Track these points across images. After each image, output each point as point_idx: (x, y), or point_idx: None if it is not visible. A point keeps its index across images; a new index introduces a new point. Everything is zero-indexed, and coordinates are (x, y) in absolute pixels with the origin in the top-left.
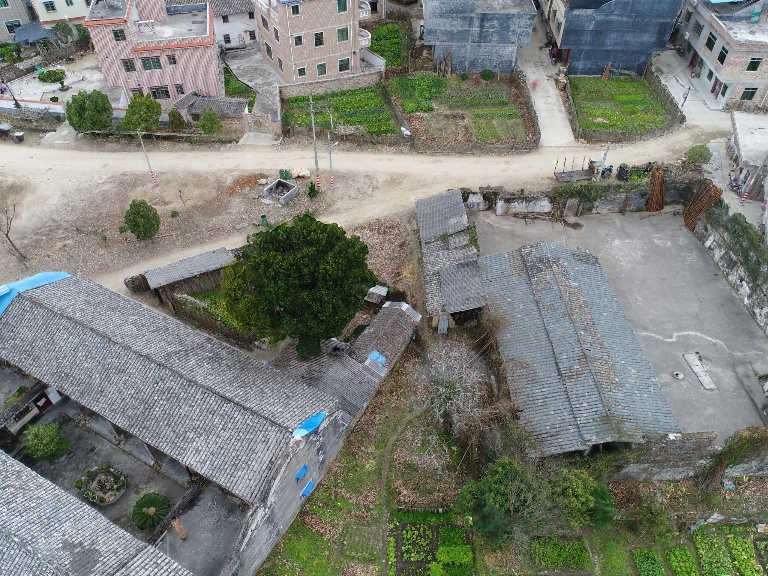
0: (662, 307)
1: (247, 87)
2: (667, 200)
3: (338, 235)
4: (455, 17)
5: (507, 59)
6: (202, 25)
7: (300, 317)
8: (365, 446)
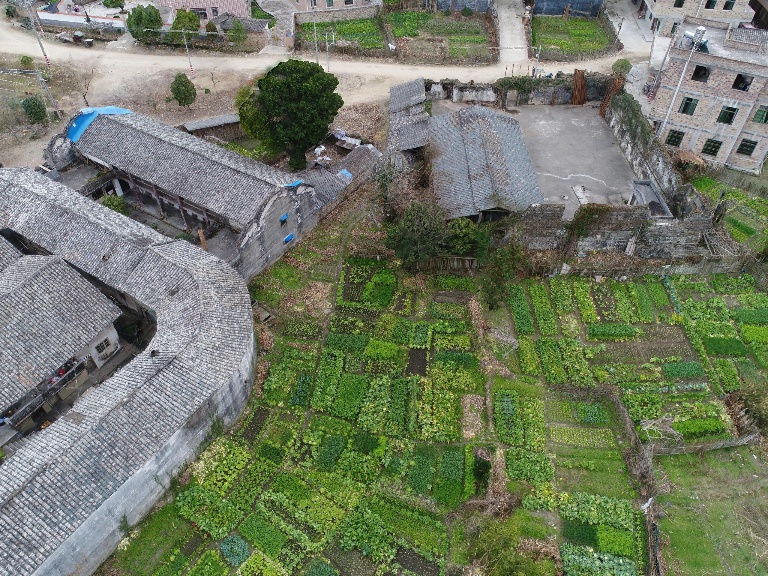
0: (565, 160)
1: (269, 15)
2: (589, 97)
3: (318, 69)
4: None
5: None
6: None
7: (290, 127)
8: (332, 226)
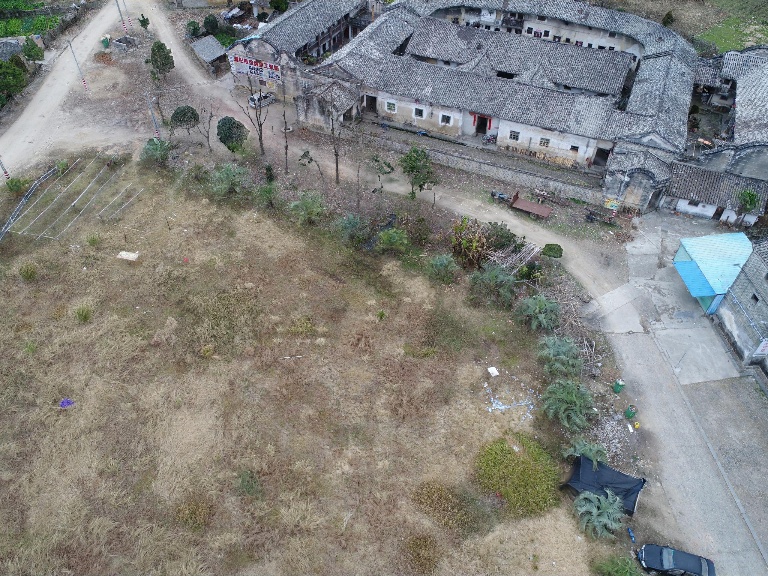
0: None
1: None
2: None
3: None
4: None
5: None
6: None
7: None
8: None
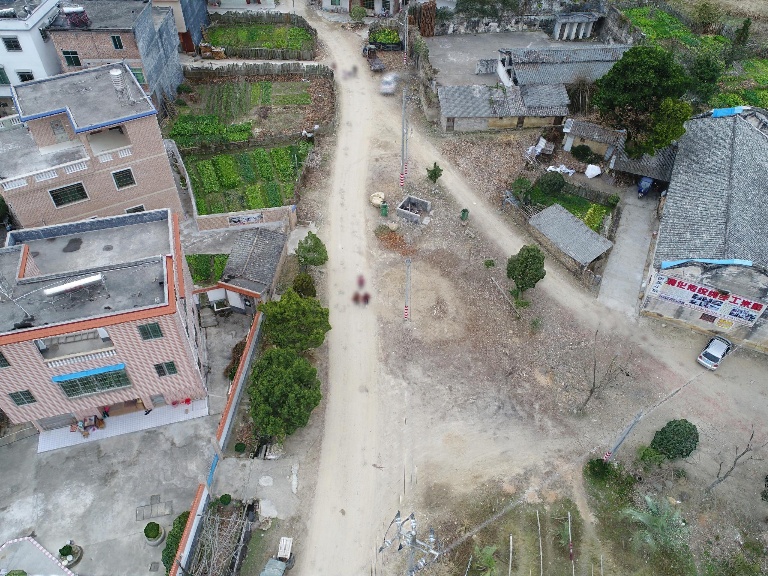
0: None
1: None
2: None
3: None
4: (152, 48)
5: (178, 65)
6: (90, 237)
7: None
8: None
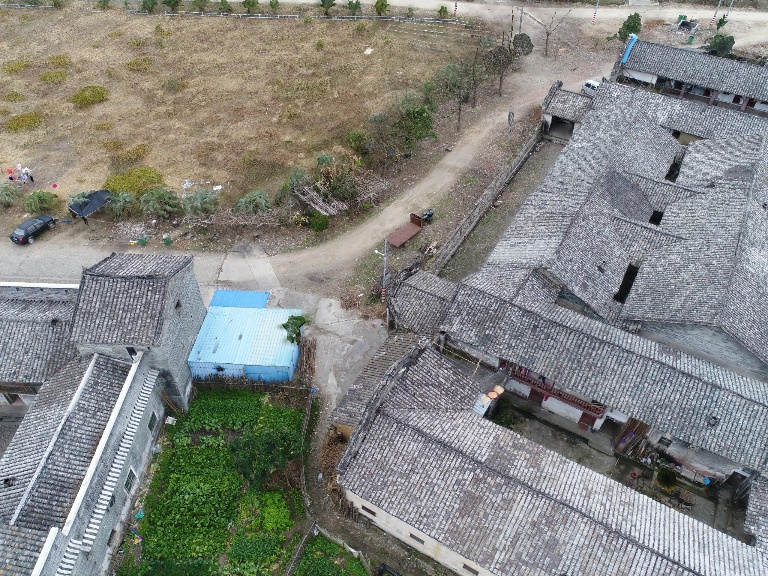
0: None
1: None
2: None
3: None
4: None
5: None
6: None
7: None
8: None
